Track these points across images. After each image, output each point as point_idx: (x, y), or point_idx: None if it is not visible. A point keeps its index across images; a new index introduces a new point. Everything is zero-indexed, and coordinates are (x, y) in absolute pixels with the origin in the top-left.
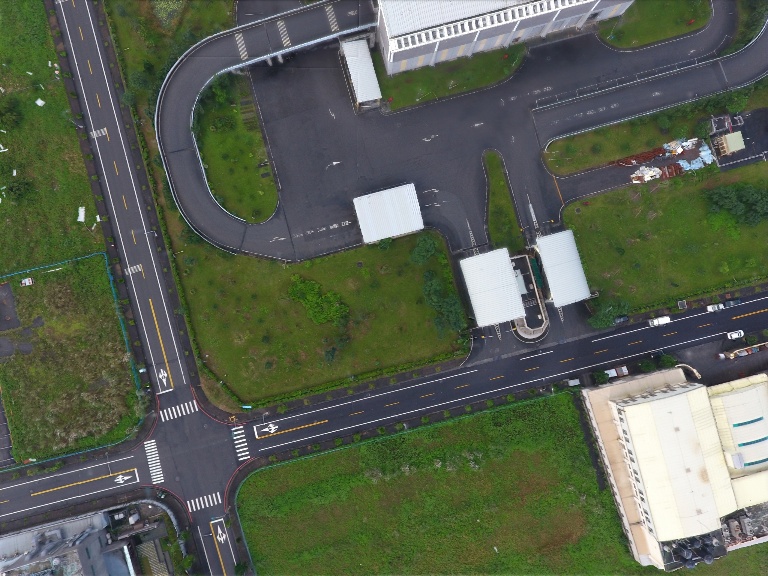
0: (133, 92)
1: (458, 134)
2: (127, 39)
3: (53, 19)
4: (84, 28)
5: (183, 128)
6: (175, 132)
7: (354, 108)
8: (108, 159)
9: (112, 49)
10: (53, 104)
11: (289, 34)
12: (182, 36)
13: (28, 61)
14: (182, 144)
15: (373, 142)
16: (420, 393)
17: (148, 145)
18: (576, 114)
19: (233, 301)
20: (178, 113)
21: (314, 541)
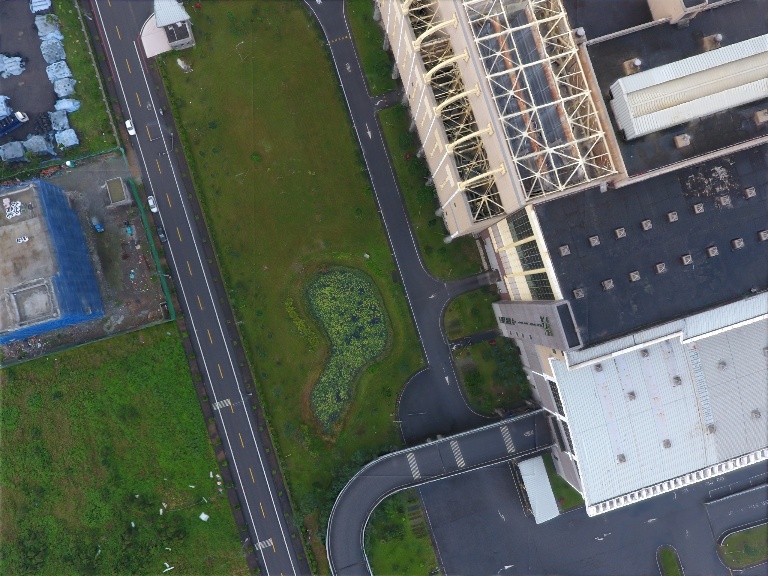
0: (304, 517)
1: (631, 531)
2: (289, 445)
3: (212, 427)
4: (244, 434)
5: (353, 543)
6: (345, 548)
7: (524, 509)
8: (275, 571)
9: (274, 455)
10: (218, 519)
11: (463, 454)
12: (353, 458)
13: (190, 474)
14: (352, 559)
15: (545, 543)
16: None
17: (315, 556)
18: (751, 505)
19: None
20: (348, 530)
21: None
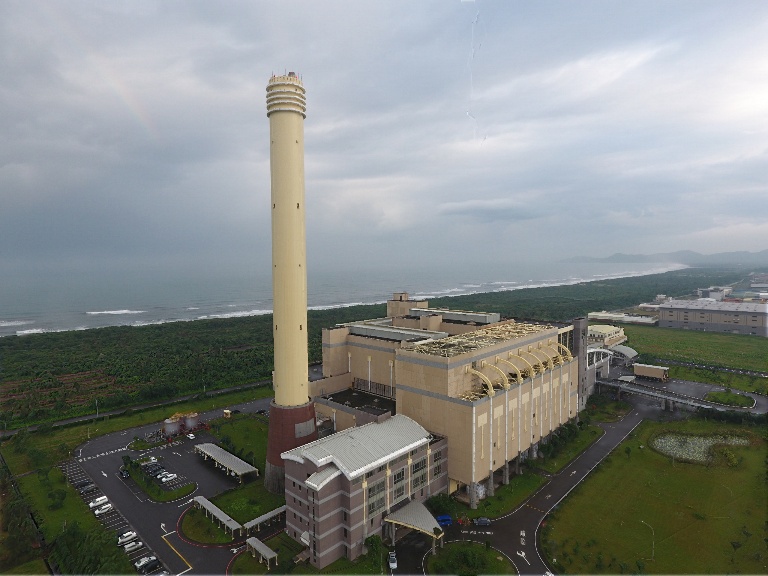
0: None
1: None
2: None
3: None
4: None
5: None
6: None
7: None
8: None
9: None
10: None
11: None
12: None
13: None
14: None
15: None
16: (679, 364)
17: None
18: None
19: (765, 389)
20: None
21: (764, 365)
